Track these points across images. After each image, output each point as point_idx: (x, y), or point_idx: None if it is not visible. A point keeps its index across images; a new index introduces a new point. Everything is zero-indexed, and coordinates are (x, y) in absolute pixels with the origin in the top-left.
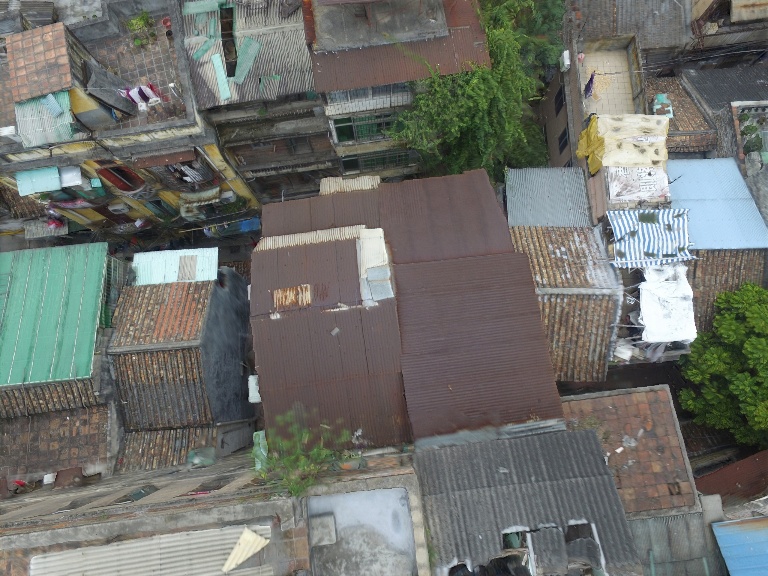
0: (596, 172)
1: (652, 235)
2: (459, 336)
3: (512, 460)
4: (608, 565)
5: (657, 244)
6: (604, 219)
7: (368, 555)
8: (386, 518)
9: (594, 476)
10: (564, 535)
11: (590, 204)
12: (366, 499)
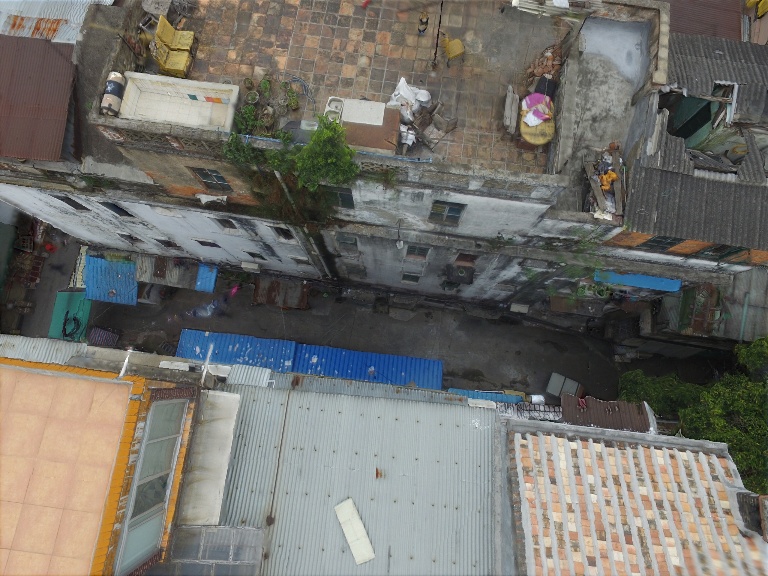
0: (766, 11)
1: None
2: (672, 8)
3: (727, 48)
4: None
5: None
6: None
7: (601, 75)
8: (622, 54)
9: None
10: None
11: (751, 41)
12: (608, 38)
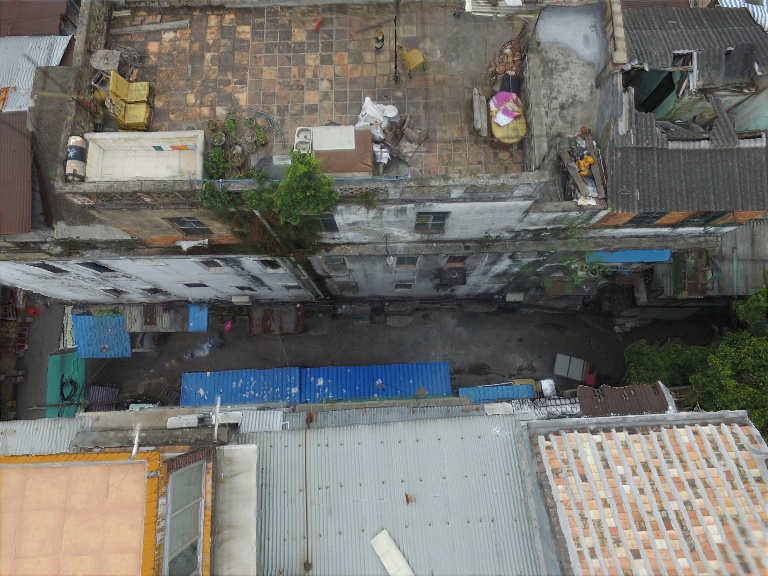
0: None
1: (756, 13)
2: None
3: (679, 17)
4: (760, 68)
5: (760, 21)
6: (711, 4)
7: (562, 63)
8: (578, 38)
9: (748, 26)
10: (724, 52)
11: (696, 0)
12: (562, 24)
